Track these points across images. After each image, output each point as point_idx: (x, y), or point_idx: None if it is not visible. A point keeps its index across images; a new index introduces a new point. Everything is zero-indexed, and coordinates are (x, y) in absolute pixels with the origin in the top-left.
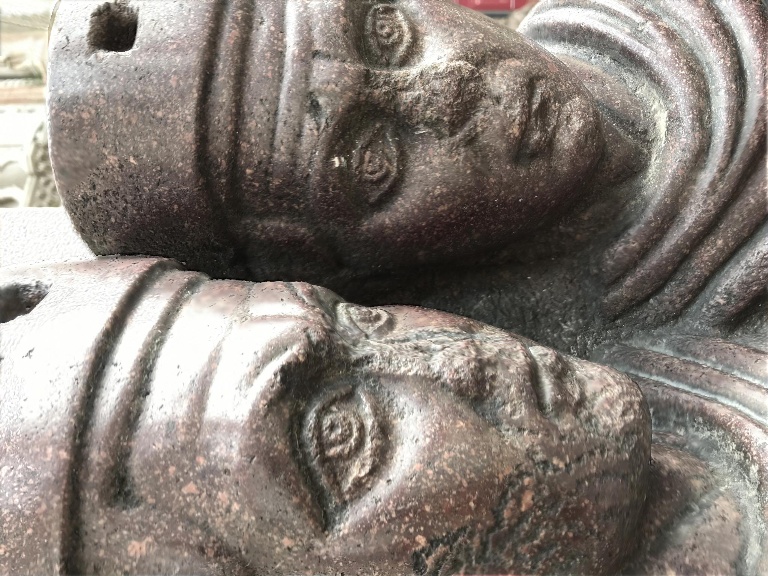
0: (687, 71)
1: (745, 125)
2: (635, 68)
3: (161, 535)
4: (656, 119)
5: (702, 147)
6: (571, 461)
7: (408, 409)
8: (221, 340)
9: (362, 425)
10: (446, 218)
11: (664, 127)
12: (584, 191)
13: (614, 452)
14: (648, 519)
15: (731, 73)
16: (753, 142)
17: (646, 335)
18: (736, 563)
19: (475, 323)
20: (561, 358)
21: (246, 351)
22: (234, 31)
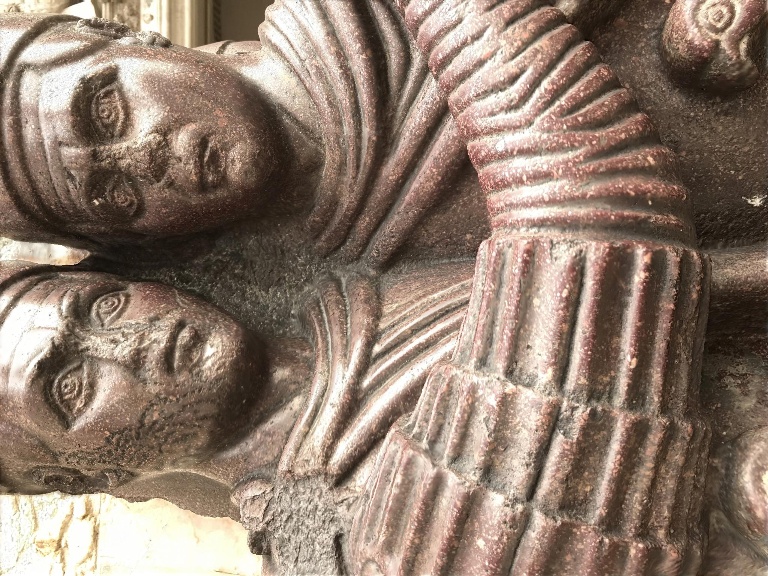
0: (327, 105)
1: (363, 148)
2: None
3: (3, 431)
4: None
5: (341, 161)
6: (180, 396)
7: (104, 374)
8: (17, 344)
9: (81, 384)
10: (178, 222)
11: None
12: (285, 181)
13: (207, 390)
14: (256, 408)
15: (350, 111)
16: (367, 161)
17: (342, 269)
18: (287, 431)
19: (163, 311)
20: (195, 337)
21: (25, 352)
22: (11, 133)
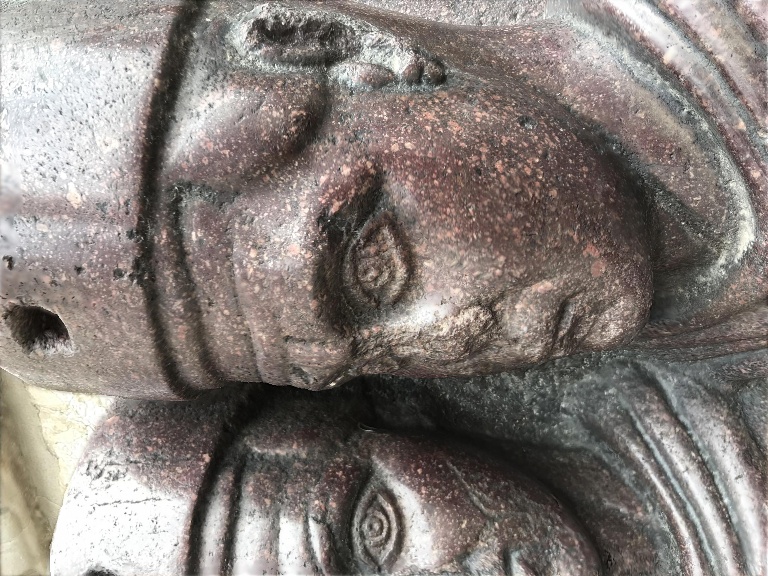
0: None
1: None
2: (736, 168)
3: None
4: (741, 225)
5: None
6: None
7: None
8: None
9: None
10: None
11: (745, 244)
12: None
13: None
14: None
15: None
16: None
17: (661, 365)
18: None
19: (472, 539)
20: None
21: None
22: (181, 326)
